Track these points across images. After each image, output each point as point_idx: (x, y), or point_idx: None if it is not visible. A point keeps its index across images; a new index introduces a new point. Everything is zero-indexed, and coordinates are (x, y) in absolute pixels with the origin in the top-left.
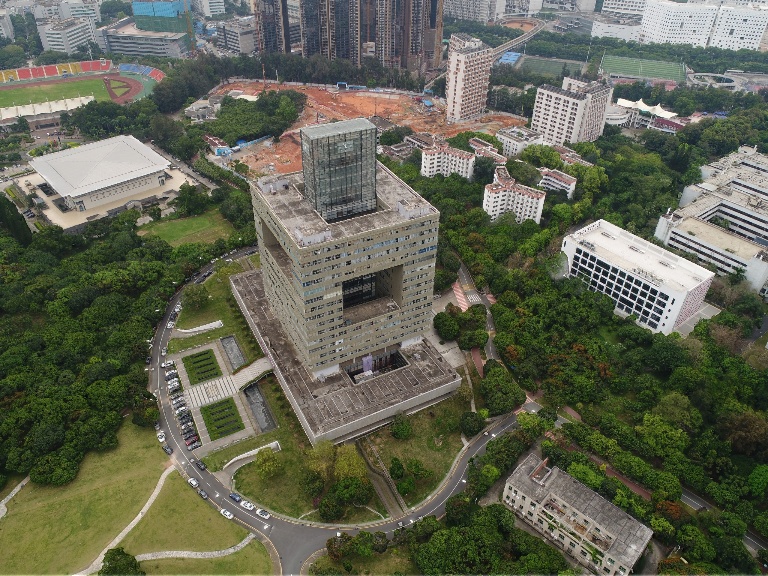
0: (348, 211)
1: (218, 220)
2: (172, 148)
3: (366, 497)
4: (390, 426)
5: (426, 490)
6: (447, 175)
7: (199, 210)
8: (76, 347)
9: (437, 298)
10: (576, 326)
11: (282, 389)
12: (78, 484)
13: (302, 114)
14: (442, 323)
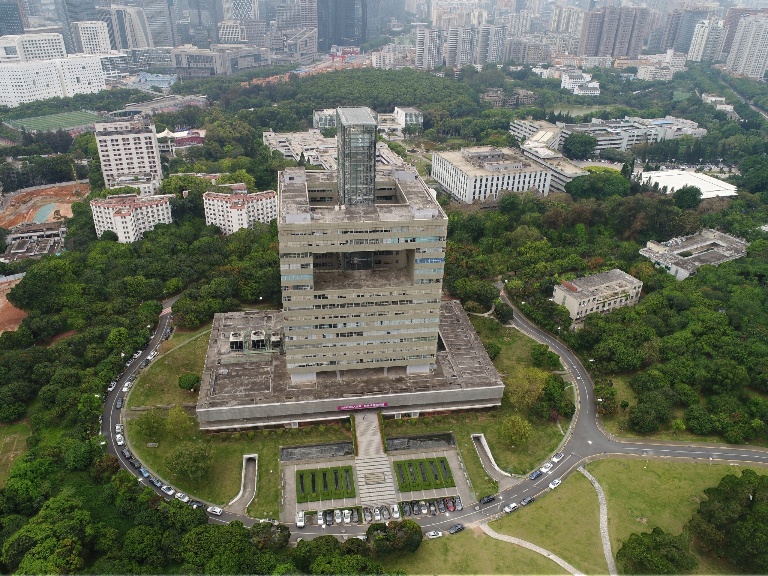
0: None
1: None
2: None
3: None
4: (488, 354)
5: None
6: None
7: None
8: None
9: None
10: None
11: None
12: None
13: None
14: None
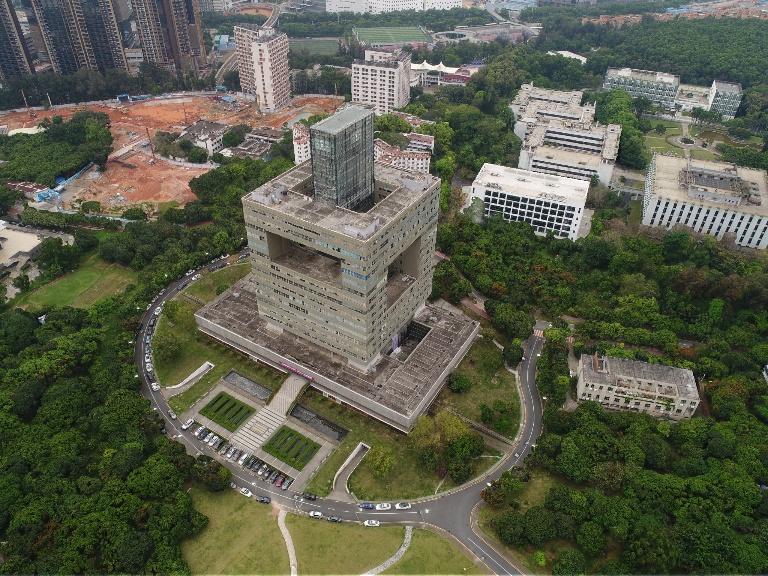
0: (357, 200)
1: (104, 268)
2: None
3: (483, 447)
4: (451, 385)
5: (514, 421)
6: None
7: (75, 264)
8: (71, 450)
9: None
10: None
11: (326, 397)
12: None
13: None
14: None
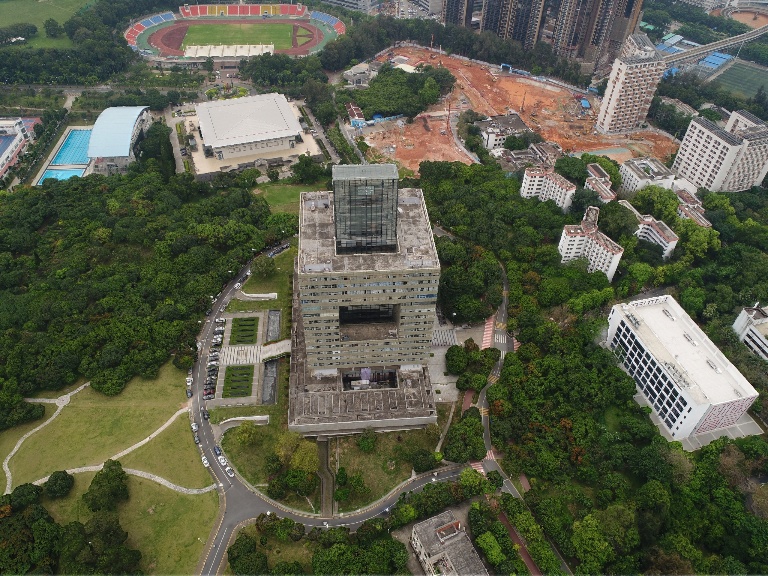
0: (367, 243)
1: None
2: (315, 112)
3: (306, 491)
4: (357, 437)
5: (360, 503)
6: (545, 199)
7: (310, 180)
8: (161, 286)
9: (466, 328)
10: (582, 400)
11: None
12: (120, 398)
13: (447, 96)
14: (451, 356)
